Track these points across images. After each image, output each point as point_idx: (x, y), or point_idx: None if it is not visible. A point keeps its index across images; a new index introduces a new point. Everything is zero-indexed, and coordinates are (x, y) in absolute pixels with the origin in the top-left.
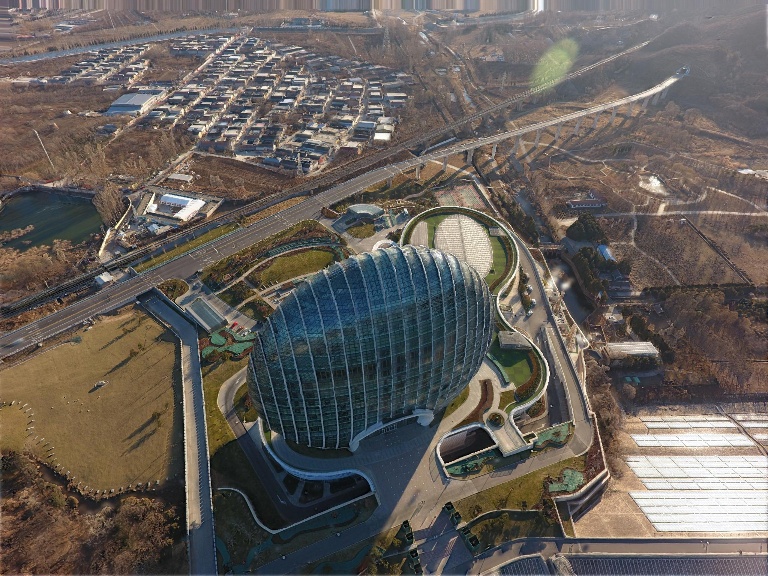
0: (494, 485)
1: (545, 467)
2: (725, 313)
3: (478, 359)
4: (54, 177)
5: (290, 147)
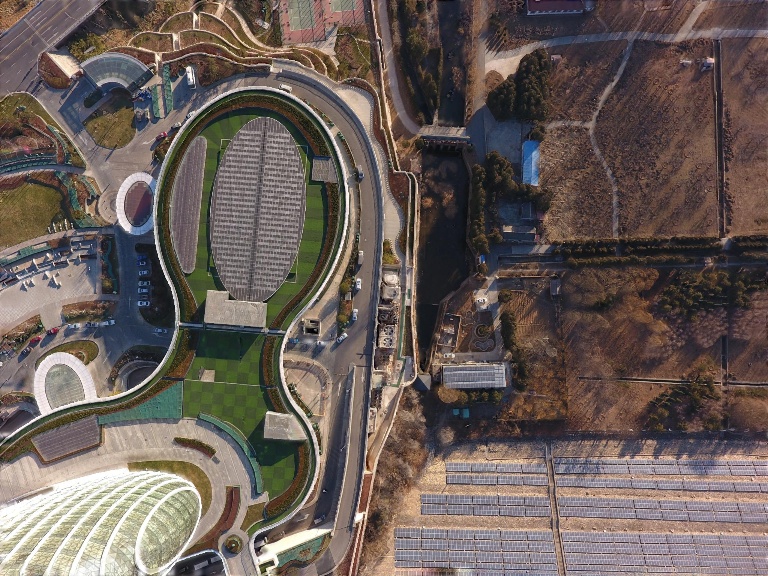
0: None
1: None
2: (636, 315)
3: None
4: None
5: None
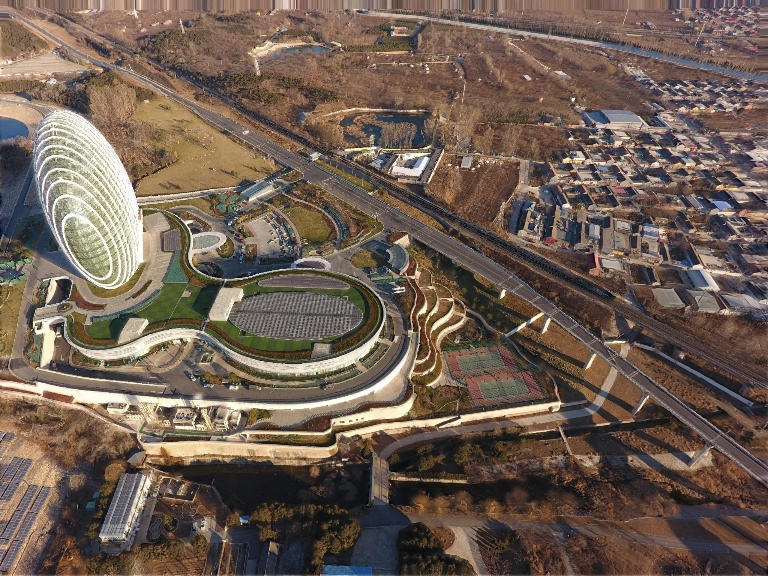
0: (22, 302)
1: (15, 335)
2: None
3: (61, 246)
4: (455, 118)
5: (570, 215)
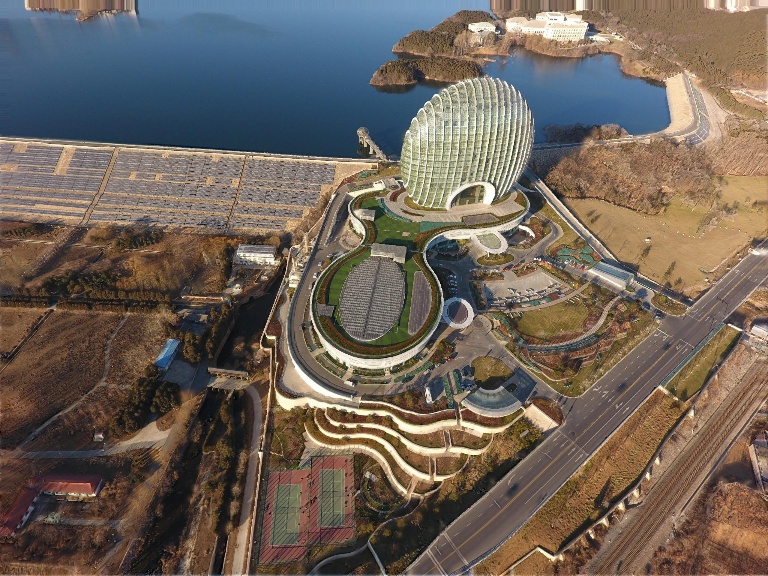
0: None
1: None
2: None
3: None
4: None
5: None
